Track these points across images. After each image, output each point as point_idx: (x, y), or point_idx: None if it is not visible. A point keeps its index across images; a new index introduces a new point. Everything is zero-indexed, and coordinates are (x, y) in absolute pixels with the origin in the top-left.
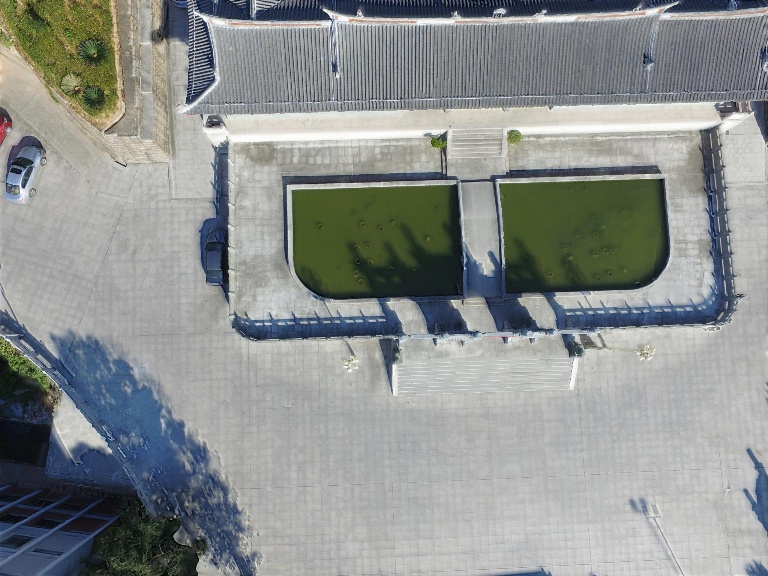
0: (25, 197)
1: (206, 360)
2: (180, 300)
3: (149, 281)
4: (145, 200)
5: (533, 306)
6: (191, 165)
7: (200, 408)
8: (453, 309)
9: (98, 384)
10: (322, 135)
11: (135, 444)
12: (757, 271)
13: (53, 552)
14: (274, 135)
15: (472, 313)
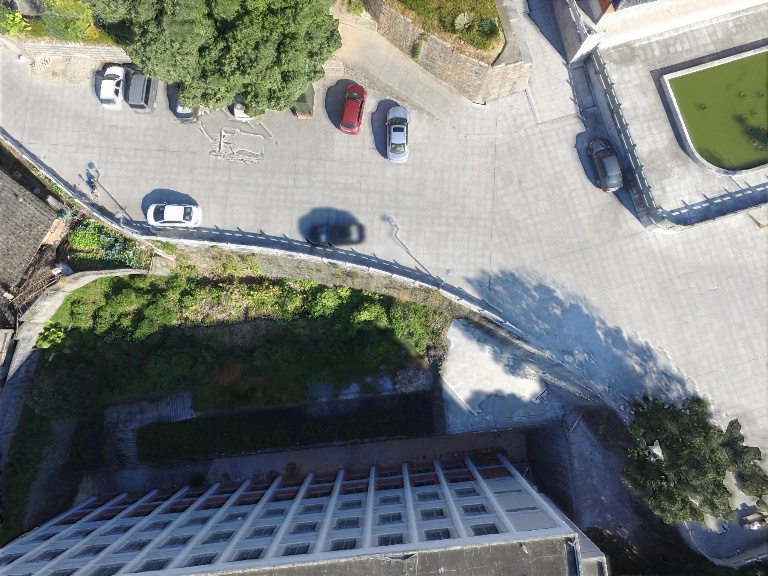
0: (407, 154)
1: (622, 265)
2: (578, 215)
3: (543, 205)
4: (514, 131)
5: None
6: (548, 87)
7: (631, 311)
8: None
9: (527, 313)
10: (685, 20)
11: (581, 361)
12: None
13: (510, 491)
14: (642, 30)
15: None
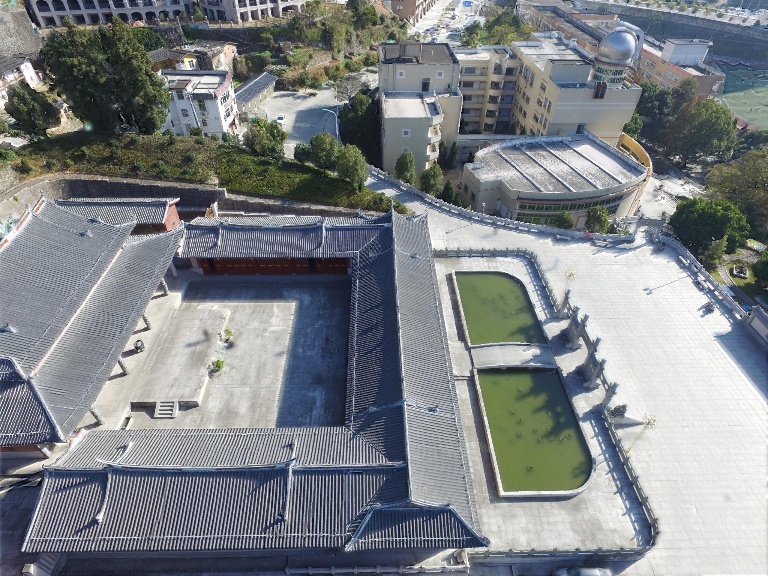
0: None
1: None
2: None
3: None
4: None
5: (550, 333)
6: None
7: None
8: (568, 377)
9: None
10: None
11: None
12: (494, 246)
13: None
14: None
15: (566, 366)
